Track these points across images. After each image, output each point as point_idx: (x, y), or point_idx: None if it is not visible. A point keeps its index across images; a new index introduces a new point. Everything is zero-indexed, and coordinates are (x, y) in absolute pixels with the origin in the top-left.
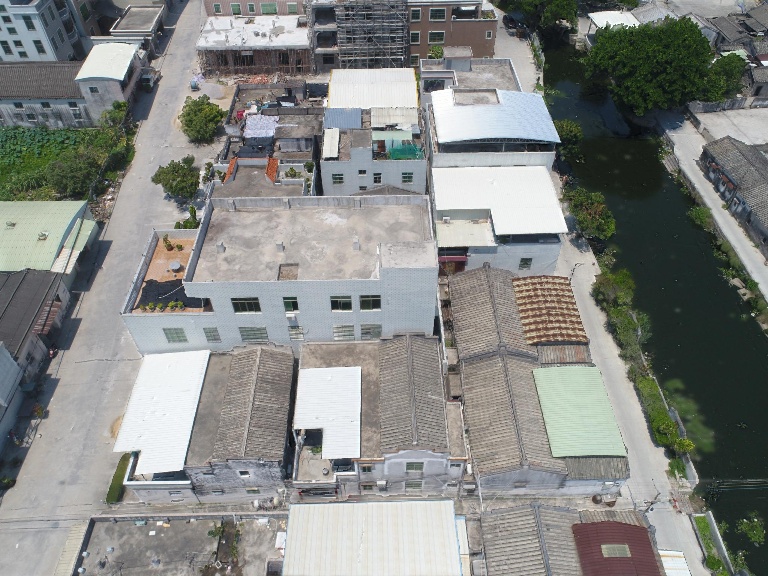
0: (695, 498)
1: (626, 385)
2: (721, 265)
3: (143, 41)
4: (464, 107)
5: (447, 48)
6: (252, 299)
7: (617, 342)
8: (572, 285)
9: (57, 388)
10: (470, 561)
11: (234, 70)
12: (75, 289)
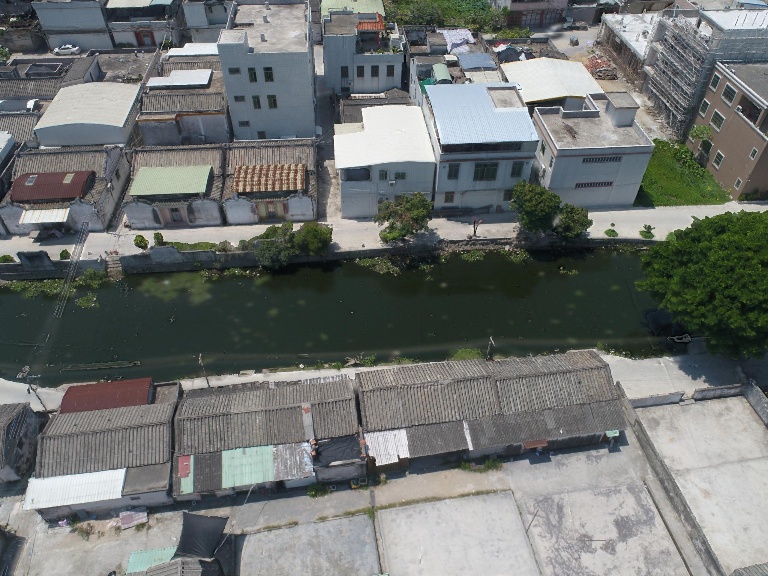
0: (121, 275)
1: None
2: (380, 358)
3: (614, 4)
4: (485, 93)
5: (628, 94)
6: None
7: None
8: (334, 230)
9: None
10: None
11: (609, 51)
12: None
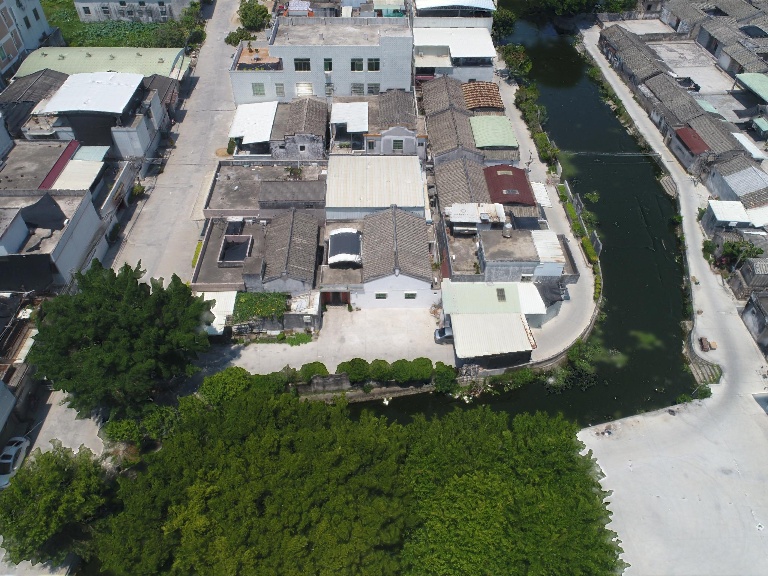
0: None
1: (529, 140)
2: (602, 96)
3: None
4: None
5: None
6: (306, 60)
7: (527, 123)
8: (502, 100)
9: (179, 137)
10: (428, 189)
11: None
12: (180, 97)
